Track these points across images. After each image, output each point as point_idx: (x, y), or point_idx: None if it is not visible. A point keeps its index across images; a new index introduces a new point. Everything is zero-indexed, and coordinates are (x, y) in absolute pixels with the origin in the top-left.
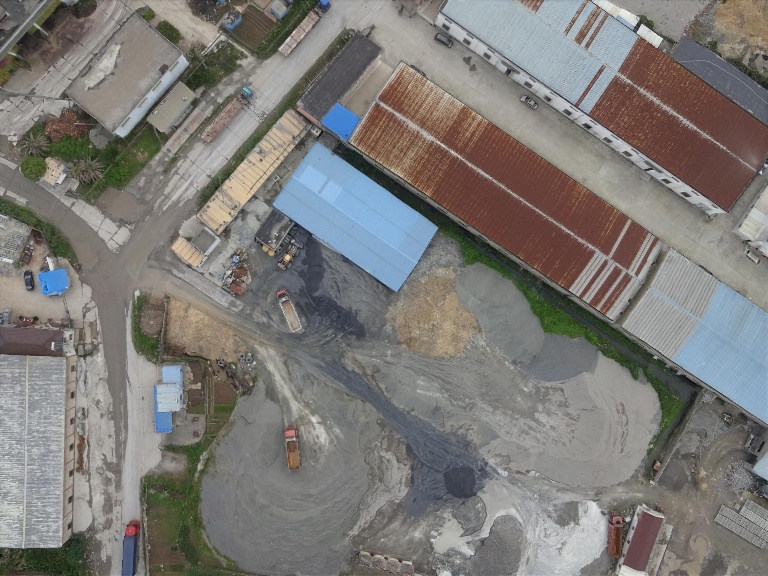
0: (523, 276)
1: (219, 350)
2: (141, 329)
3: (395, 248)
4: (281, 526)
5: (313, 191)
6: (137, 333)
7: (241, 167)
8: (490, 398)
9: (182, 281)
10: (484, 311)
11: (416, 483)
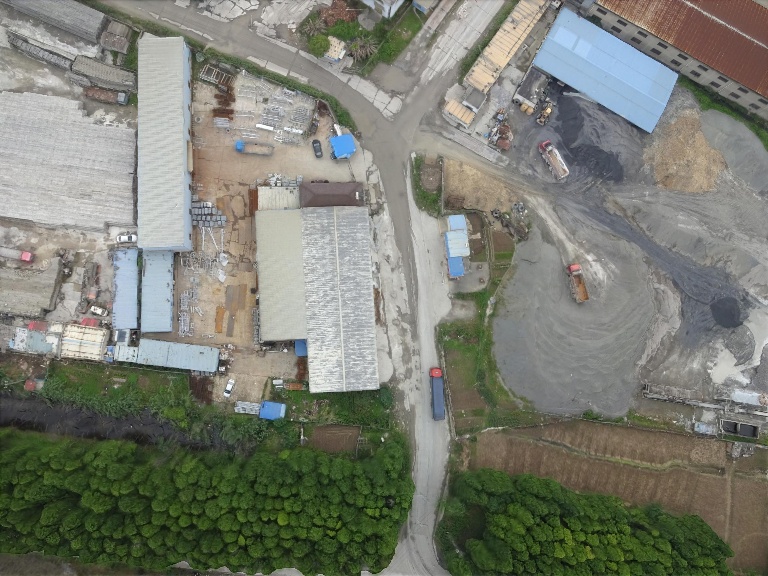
0: (752, 119)
1: (495, 200)
2: (421, 187)
3: (645, 94)
4: (580, 355)
5: (567, 48)
6: (418, 191)
7: (498, 35)
8: (745, 228)
9: (452, 142)
10: (730, 146)
11: (686, 316)
